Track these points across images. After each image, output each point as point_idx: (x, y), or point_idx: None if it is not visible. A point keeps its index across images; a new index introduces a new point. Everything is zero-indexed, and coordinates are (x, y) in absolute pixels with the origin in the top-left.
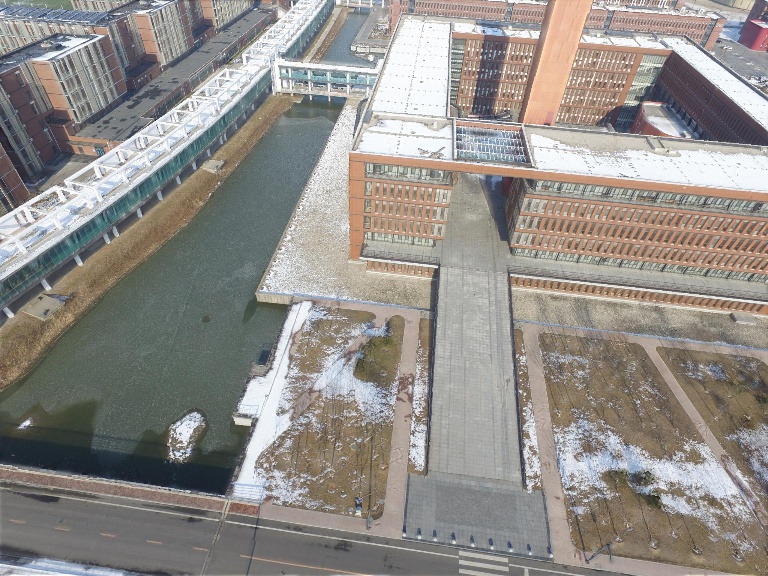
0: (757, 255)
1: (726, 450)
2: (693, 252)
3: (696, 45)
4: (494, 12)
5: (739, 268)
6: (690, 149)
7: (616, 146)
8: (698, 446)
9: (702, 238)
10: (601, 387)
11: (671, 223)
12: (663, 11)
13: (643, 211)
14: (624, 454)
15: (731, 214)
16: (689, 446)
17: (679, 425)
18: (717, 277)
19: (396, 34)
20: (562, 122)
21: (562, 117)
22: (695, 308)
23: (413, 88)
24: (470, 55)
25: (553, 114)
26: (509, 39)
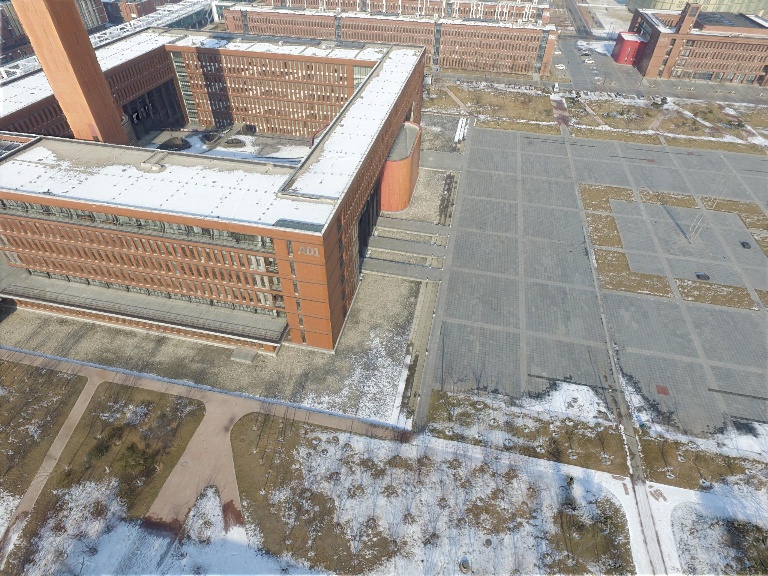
0: (225, 284)
1: (35, 506)
2: (167, 278)
3: (418, 56)
4: (324, 26)
5: (223, 298)
6: (187, 165)
7: (107, 160)
8: (5, 499)
9: (160, 263)
10: None
11: (118, 245)
12: (500, 23)
13: (83, 231)
14: None
15: (161, 237)
16: None
17: (14, 473)
18: (225, 307)
19: (103, 47)
20: (300, 137)
21: (302, 132)
22: (200, 340)
23: (8, 99)
24: (191, 68)
25: (93, 126)
26: (219, 51)
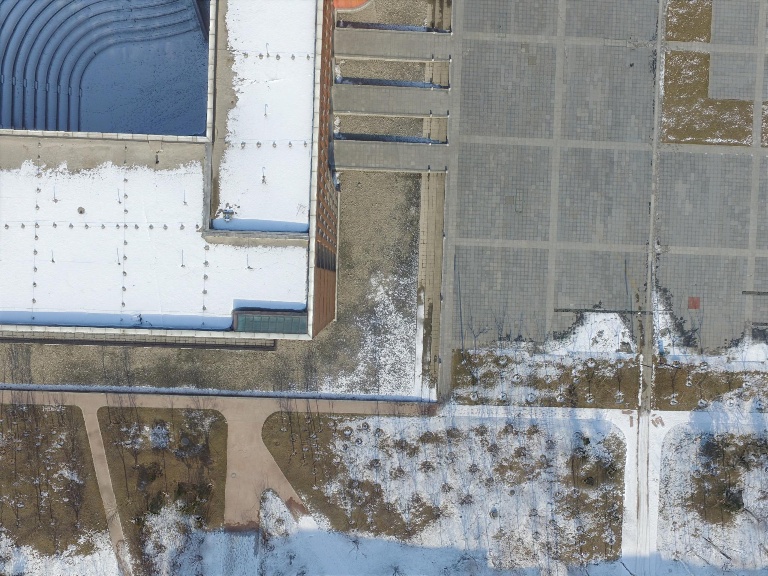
0: None
1: (125, 535)
2: None
3: None
4: None
5: None
6: (4, 163)
7: None
8: (95, 536)
9: None
10: (6, 482)
11: None
12: None
13: None
14: (13, 557)
15: None
16: (85, 539)
17: (84, 515)
18: None
19: None
20: None
21: None
22: None
23: None
24: None
25: None
26: None
